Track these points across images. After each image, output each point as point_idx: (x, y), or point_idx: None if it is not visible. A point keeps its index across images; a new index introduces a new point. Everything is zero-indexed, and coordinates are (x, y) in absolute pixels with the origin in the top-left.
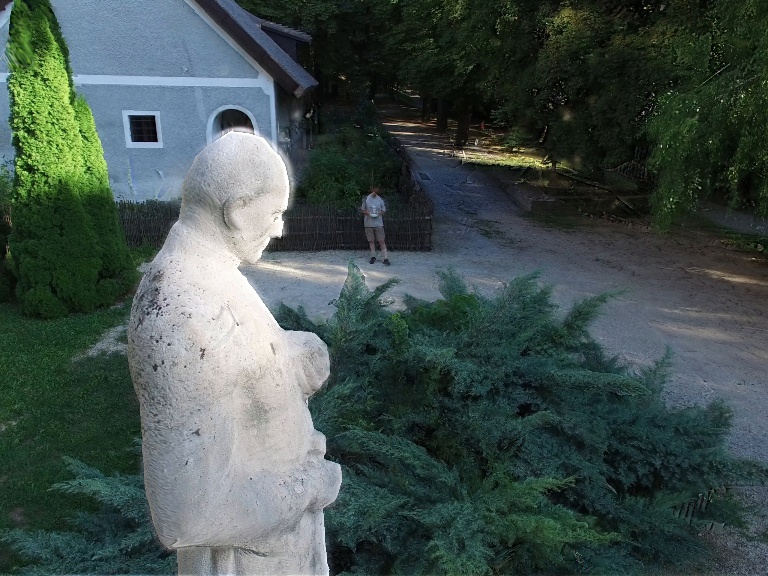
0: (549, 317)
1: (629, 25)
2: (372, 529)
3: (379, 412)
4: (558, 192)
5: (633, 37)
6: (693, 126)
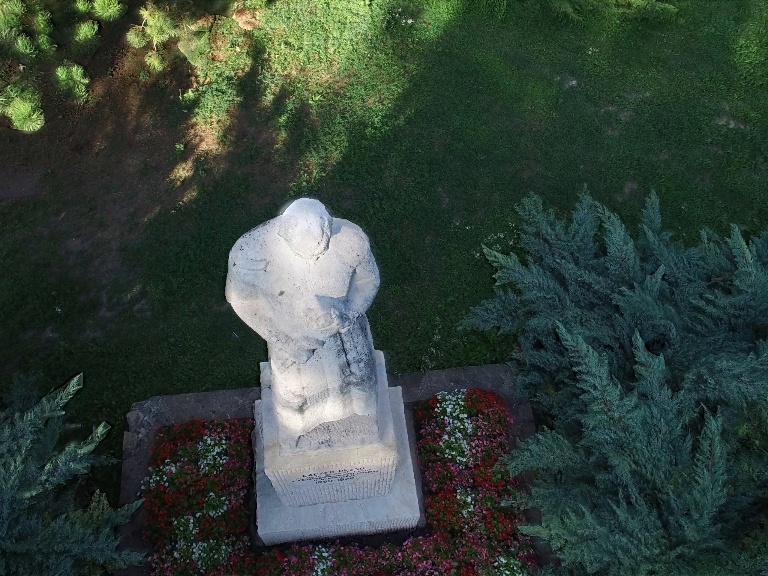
0: None
1: None
2: None
3: None
4: None
5: None
6: None
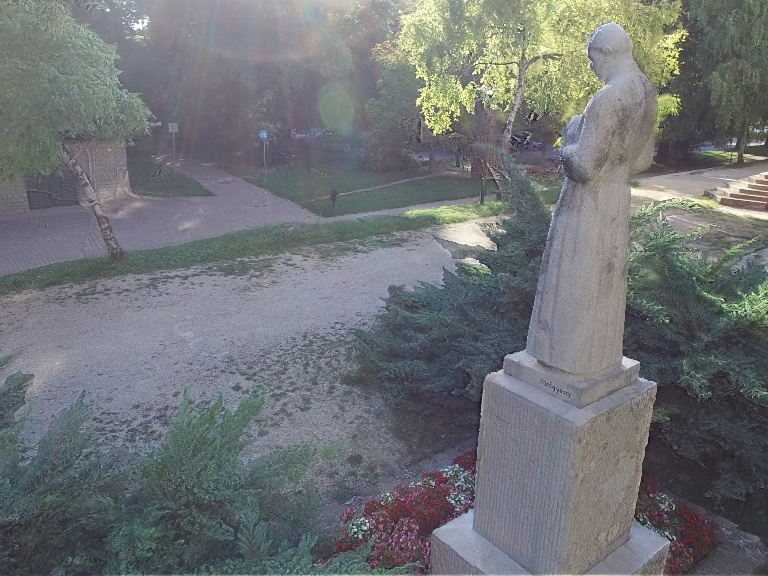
0: None
1: None
2: None
3: None
4: None
5: None
6: None
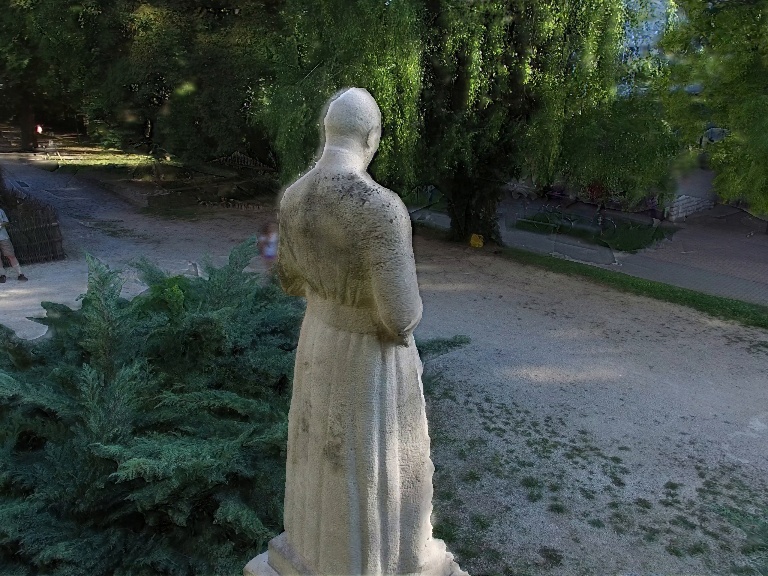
0: (258, 279)
1: (213, 25)
2: (228, 465)
3: (170, 384)
4: (175, 184)
5: (218, 36)
6: (308, 112)
